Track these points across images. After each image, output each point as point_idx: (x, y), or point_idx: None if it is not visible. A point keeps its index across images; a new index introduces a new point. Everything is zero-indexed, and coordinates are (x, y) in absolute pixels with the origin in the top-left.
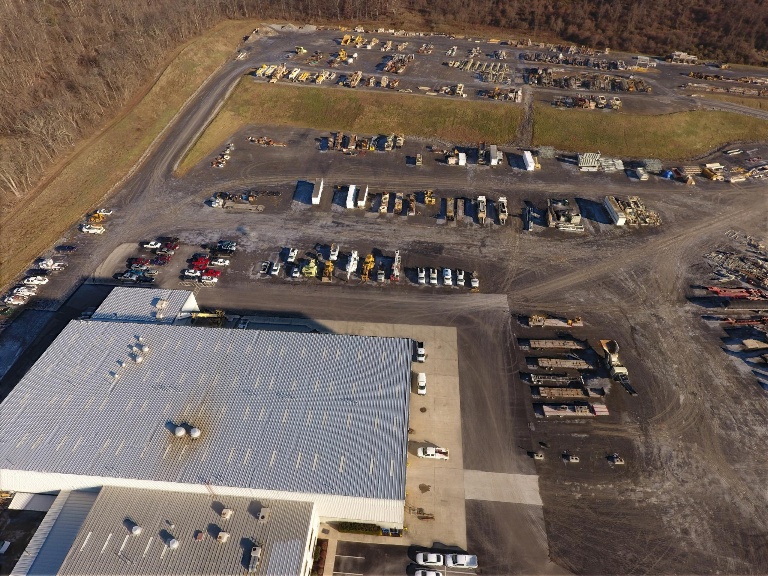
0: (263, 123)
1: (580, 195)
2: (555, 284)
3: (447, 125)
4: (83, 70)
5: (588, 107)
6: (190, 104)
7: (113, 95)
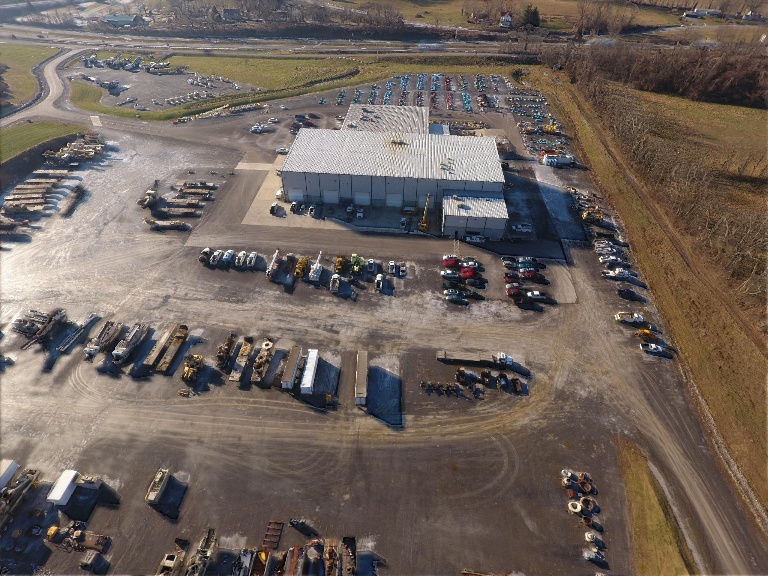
0: None
1: None
2: (131, 255)
3: None
4: None
5: None
6: None
7: None
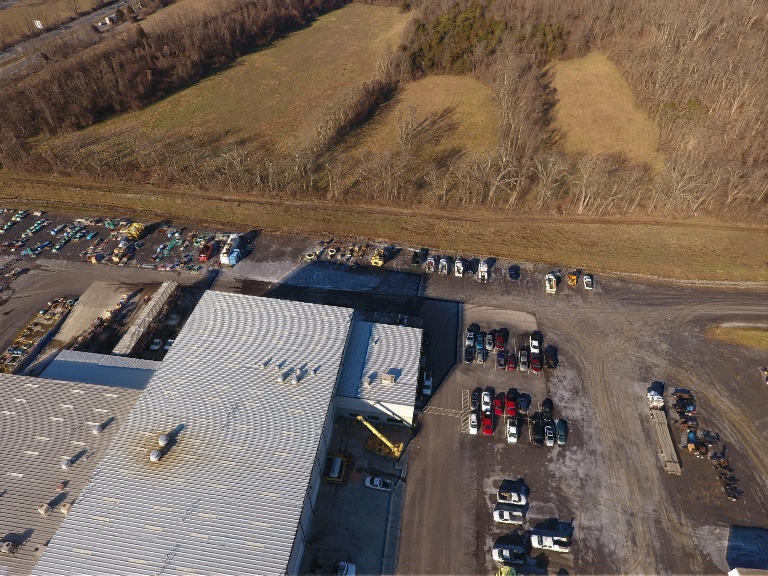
0: None
1: None
2: None
3: None
4: None
5: None
6: None
7: None
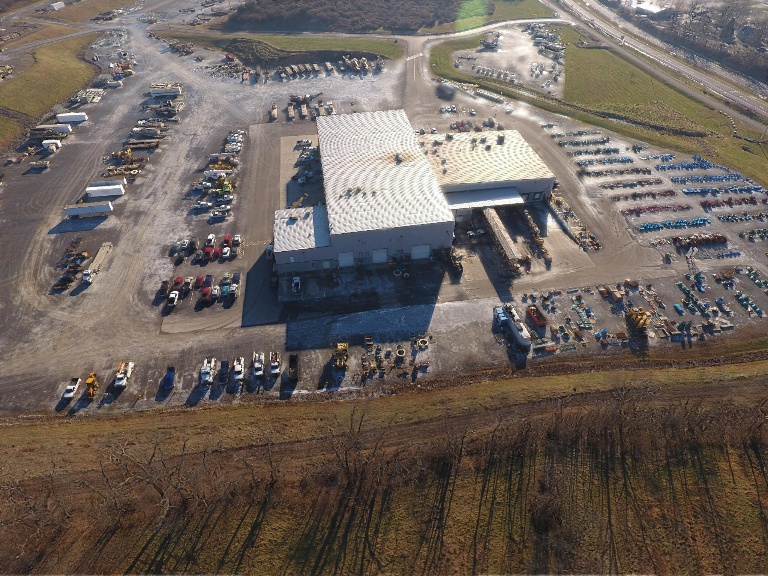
0: None
1: (136, 104)
2: (239, 113)
3: None
4: None
5: None
6: None
7: None
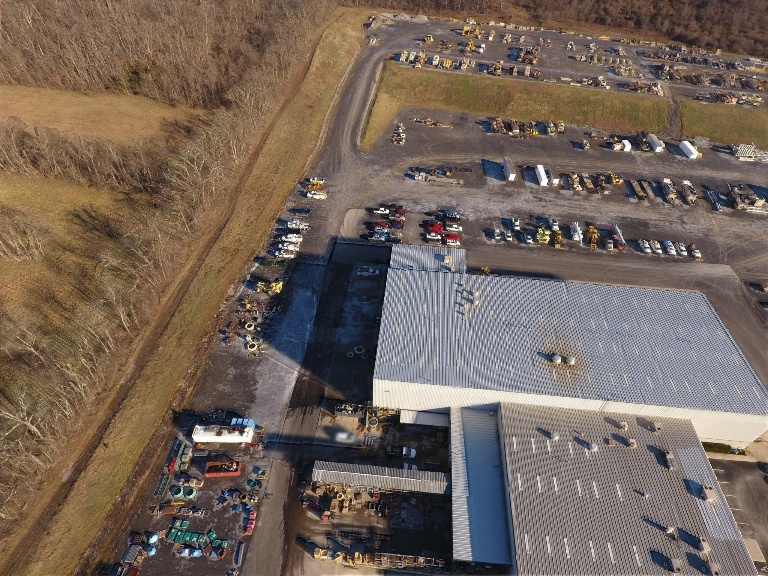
0: (419, 106)
1: (750, 182)
2: (767, 258)
3: (597, 114)
4: (250, 48)
5: (730, 103)
6: (345, 85)
7: (282, 73)
